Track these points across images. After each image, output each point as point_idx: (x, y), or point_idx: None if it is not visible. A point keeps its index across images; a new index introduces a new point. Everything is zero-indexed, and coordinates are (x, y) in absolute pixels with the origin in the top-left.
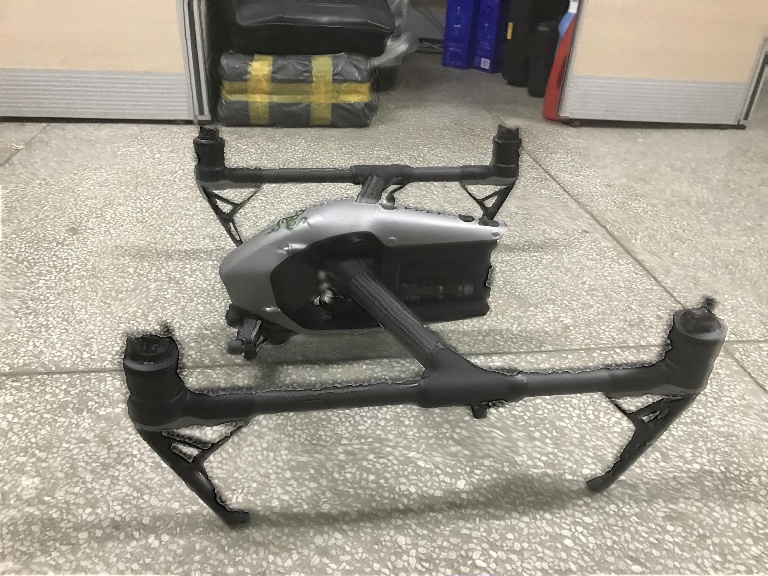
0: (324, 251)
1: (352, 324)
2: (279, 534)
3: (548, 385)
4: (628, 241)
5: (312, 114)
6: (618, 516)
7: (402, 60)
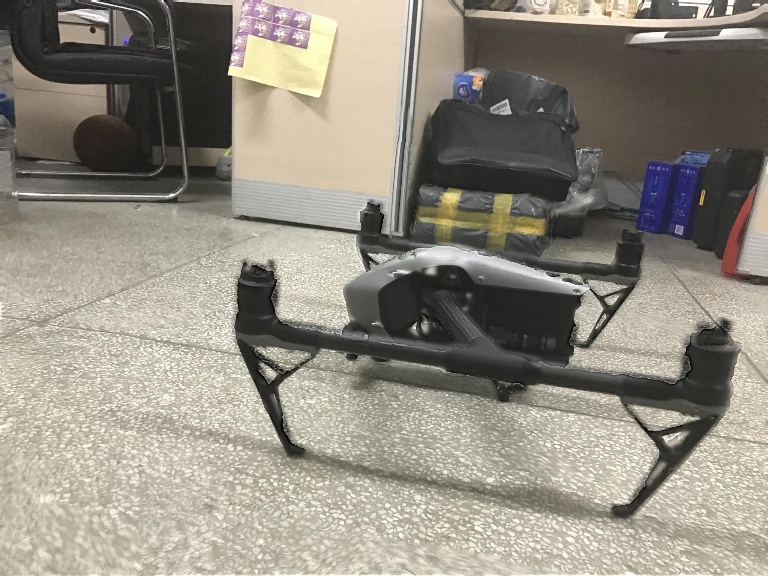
0: (423, 279)
1: None
2: (322, 468)
3: (561, 374)
4: (767, 368)
5: (488, 240)
6: (633, 538)
7: (587, 212)
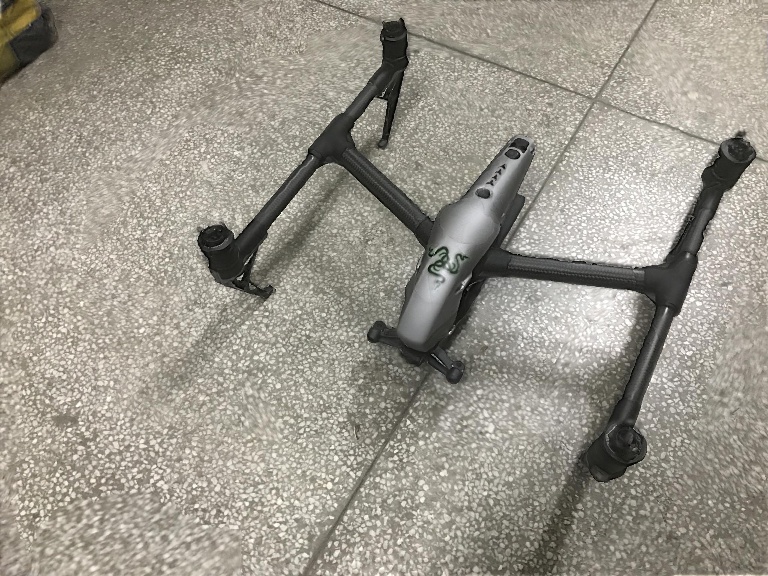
0: None
1: (477, 287)
2: None
3: None
4: (451, 41)
5: None
6: None
7: None
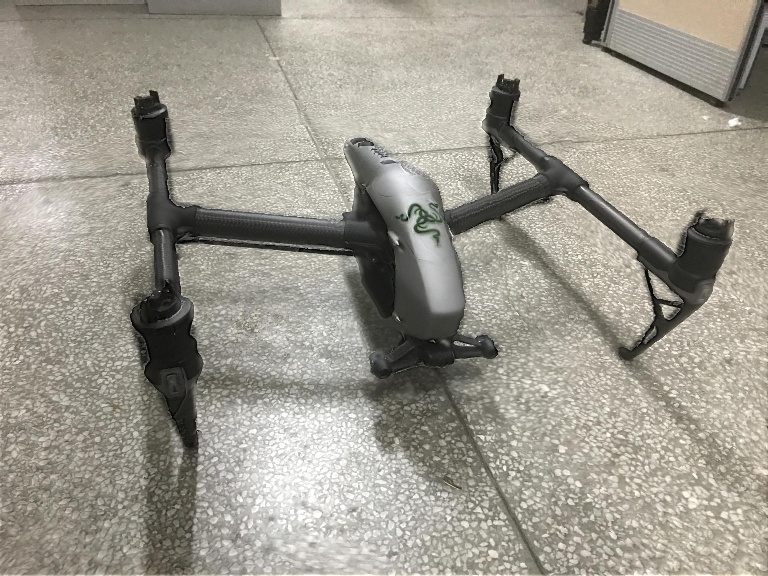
0: None
1: None
2: None
3: None
4: None
5: None
6: None
7: None
